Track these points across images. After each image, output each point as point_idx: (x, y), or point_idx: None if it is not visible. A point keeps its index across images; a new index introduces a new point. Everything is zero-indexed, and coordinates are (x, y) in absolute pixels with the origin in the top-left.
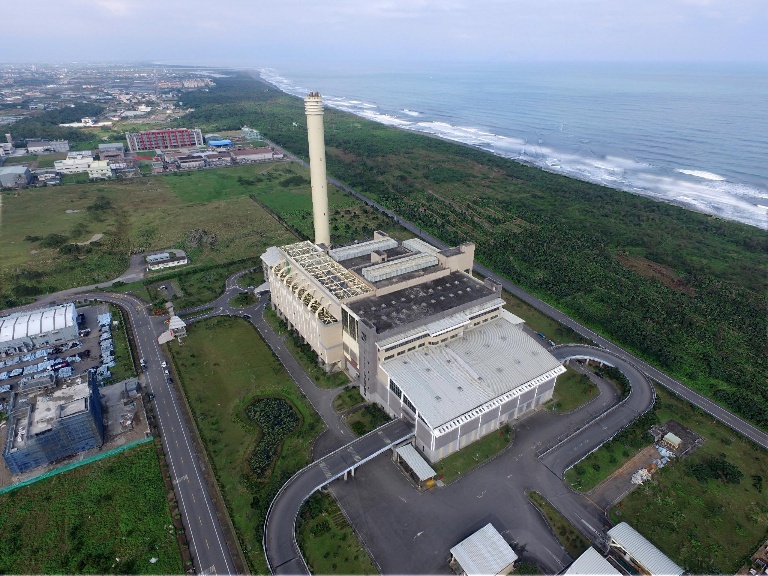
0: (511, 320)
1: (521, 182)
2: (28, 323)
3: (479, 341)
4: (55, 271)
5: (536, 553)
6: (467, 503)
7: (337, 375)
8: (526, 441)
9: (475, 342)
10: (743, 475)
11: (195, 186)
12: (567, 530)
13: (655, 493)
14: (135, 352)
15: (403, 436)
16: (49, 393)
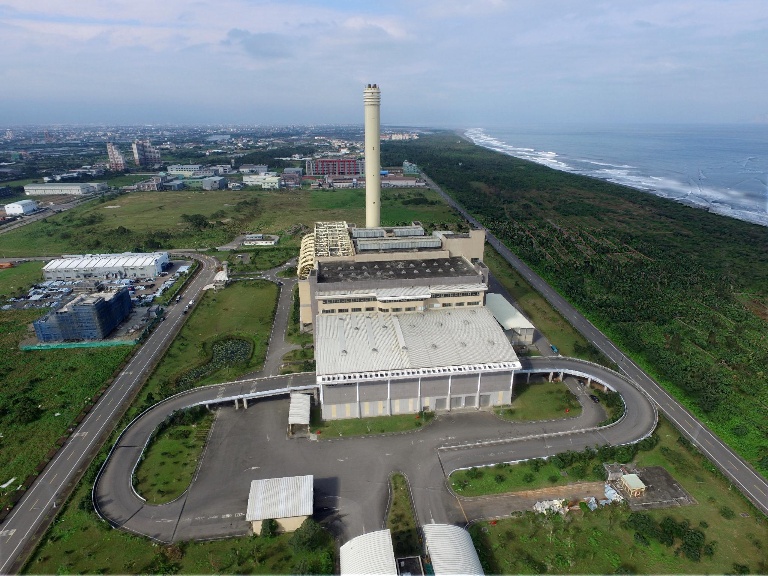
0: (517, 323)
1: (671, 221)
2: (129, 259)
3: (436, 319)
4: (180, 236)
5: (348, 526)
6: (322, 460)
7: (309, 336)
8: (439, 431)
9: (430, 319)
10: (713, 554)
11: (330, 198)
12: (403, 520)
13: (555, 528)
14: (181, 291)
15: (307, 386)
16: (89, 293)
